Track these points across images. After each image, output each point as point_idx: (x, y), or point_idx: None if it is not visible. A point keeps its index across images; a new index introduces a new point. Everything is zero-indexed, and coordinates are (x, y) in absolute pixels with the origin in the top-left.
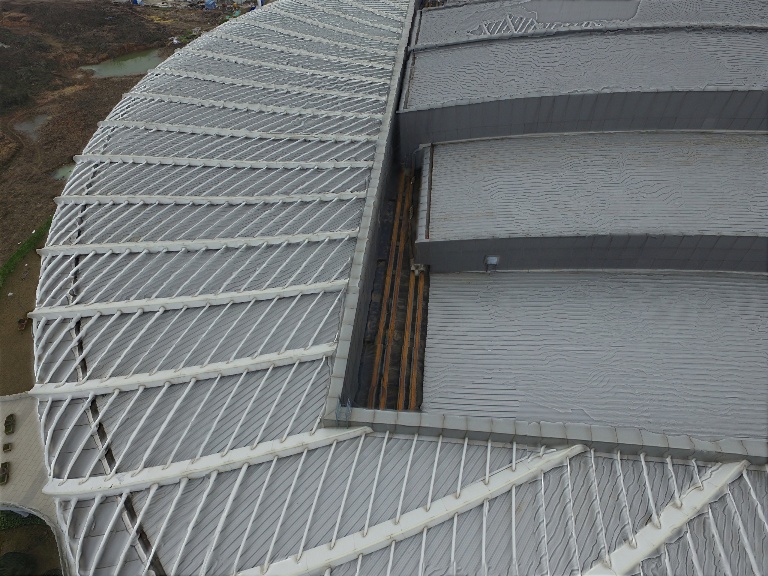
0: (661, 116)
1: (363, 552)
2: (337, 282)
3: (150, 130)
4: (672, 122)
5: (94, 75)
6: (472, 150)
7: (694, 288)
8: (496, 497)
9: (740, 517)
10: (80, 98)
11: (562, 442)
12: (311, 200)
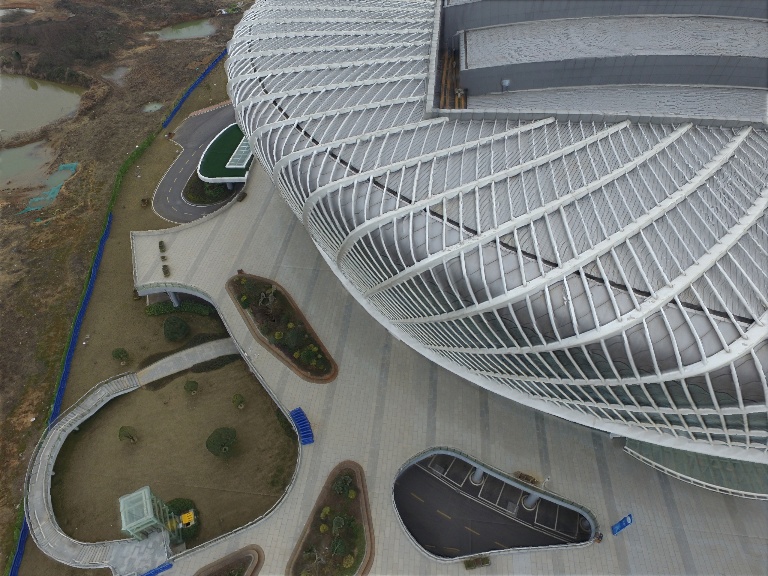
0: (611, 5)
1: (450, 152)
2: (421, 74)
3: (279, 23)
4: (619, 9)
5: (159, 38)
6: (492, 32)
7: (623, 89)
8: (511, 136)
9: (622, 136)
10: (151, 55)
11: (542, 115)
12: (398, 46)
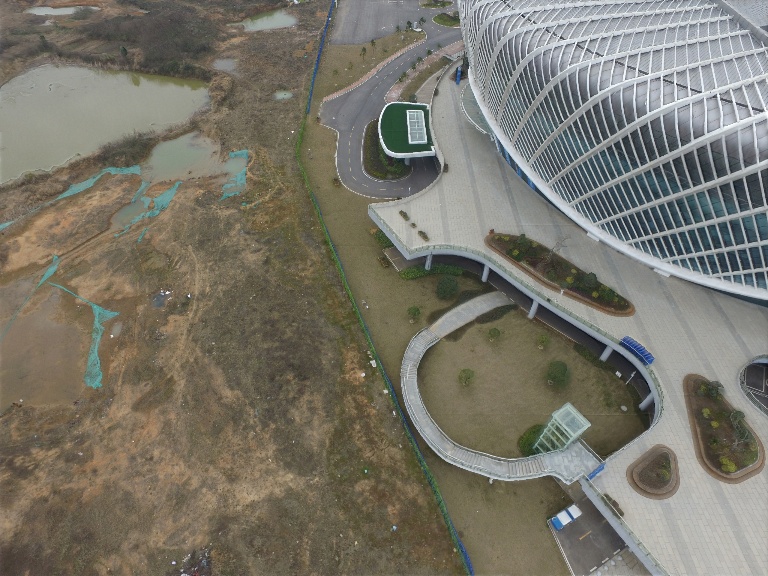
0: None
1: None
2: None
3: None
4: None
5: (245, 29)
6: None
7: None
8: None
9: None
10: (249, 46)
11: None
12: (690, 10)
